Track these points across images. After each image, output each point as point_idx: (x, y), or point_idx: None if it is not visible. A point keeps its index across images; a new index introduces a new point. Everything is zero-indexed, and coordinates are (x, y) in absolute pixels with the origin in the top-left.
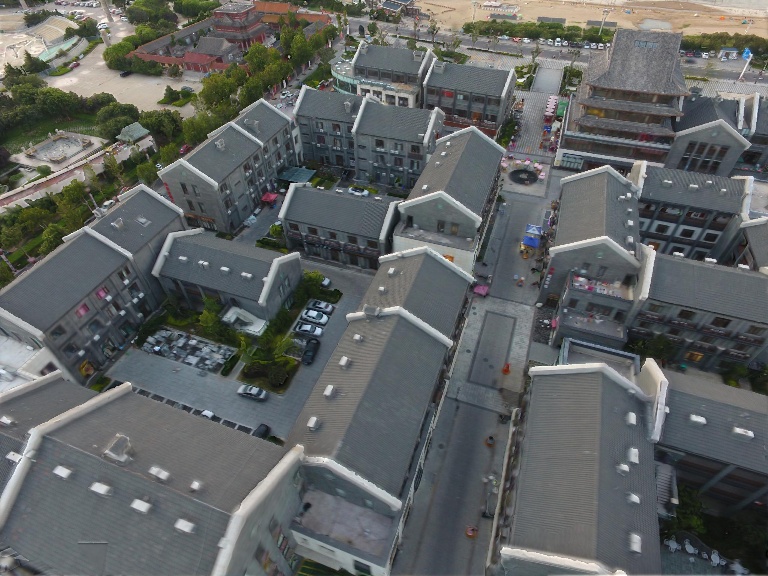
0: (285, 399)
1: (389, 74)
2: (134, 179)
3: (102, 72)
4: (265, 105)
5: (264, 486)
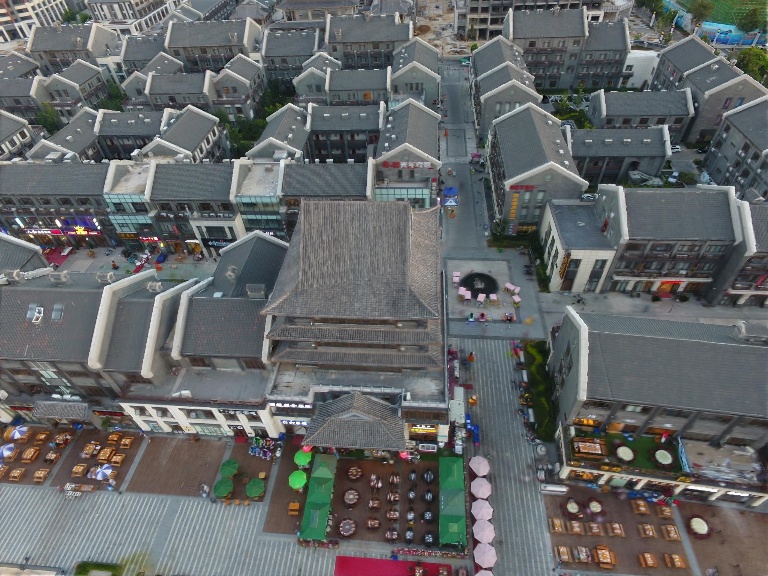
0: (548, 111)
1: None
2: None
3: None
4: None
5: (511, 18)
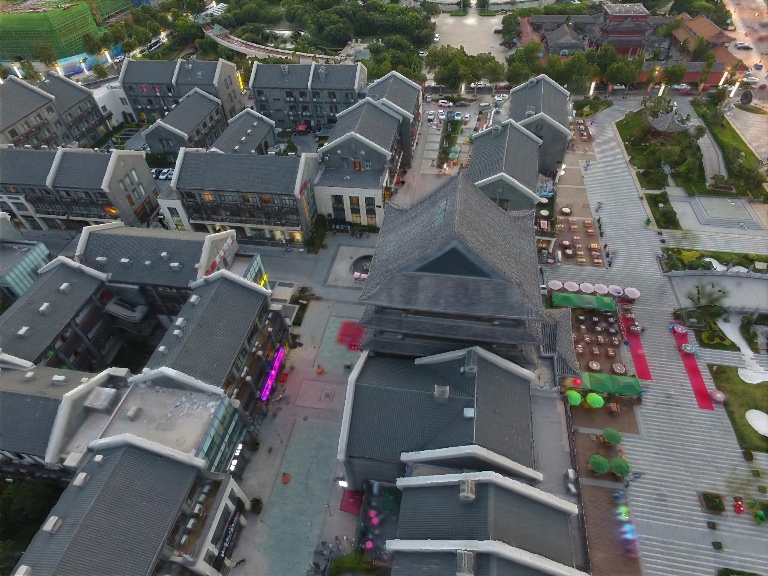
0: None
1: None
2: None
3: (499, 24)
4: None
5: None
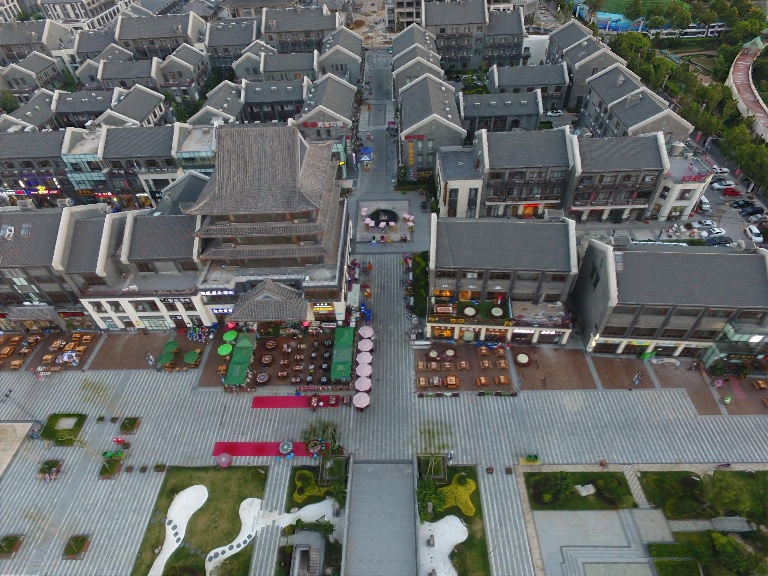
0: None
1: None
2: None
3: None
4: None
5: (423, 8)
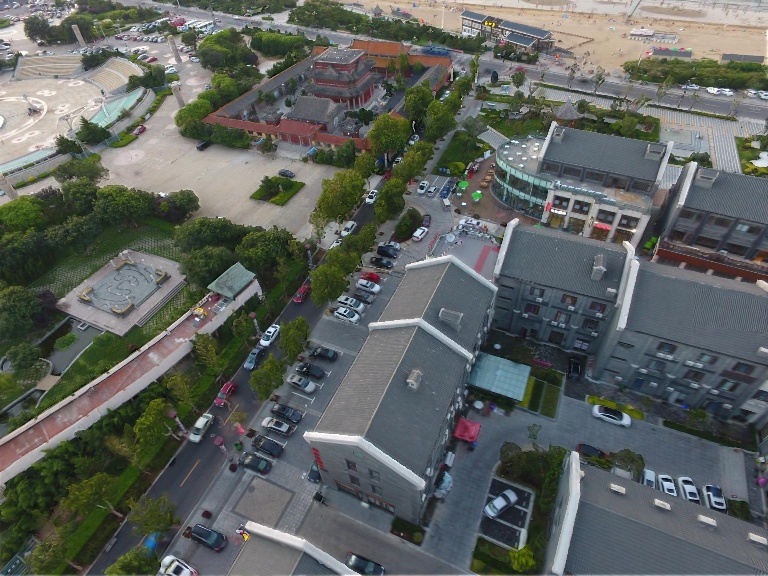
0: None
1: (600, 175)
2: (236, 361)
3: (174, 141)
4: (456, 266)
5: None
